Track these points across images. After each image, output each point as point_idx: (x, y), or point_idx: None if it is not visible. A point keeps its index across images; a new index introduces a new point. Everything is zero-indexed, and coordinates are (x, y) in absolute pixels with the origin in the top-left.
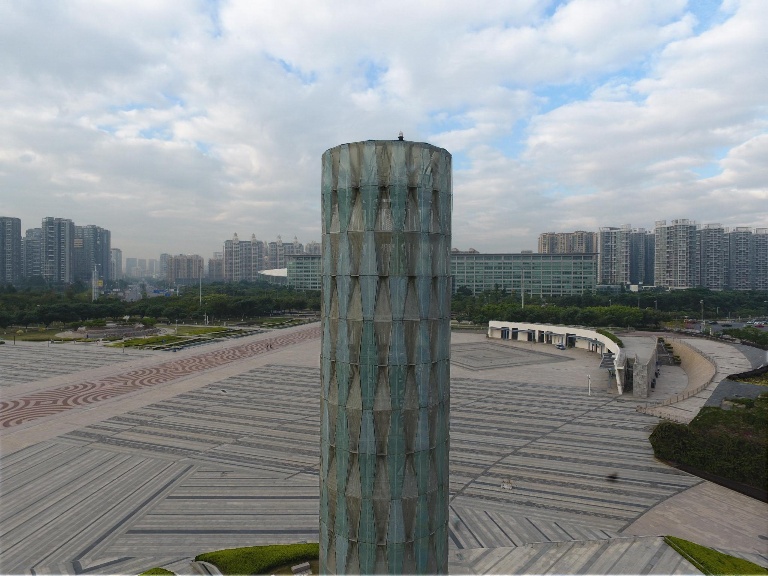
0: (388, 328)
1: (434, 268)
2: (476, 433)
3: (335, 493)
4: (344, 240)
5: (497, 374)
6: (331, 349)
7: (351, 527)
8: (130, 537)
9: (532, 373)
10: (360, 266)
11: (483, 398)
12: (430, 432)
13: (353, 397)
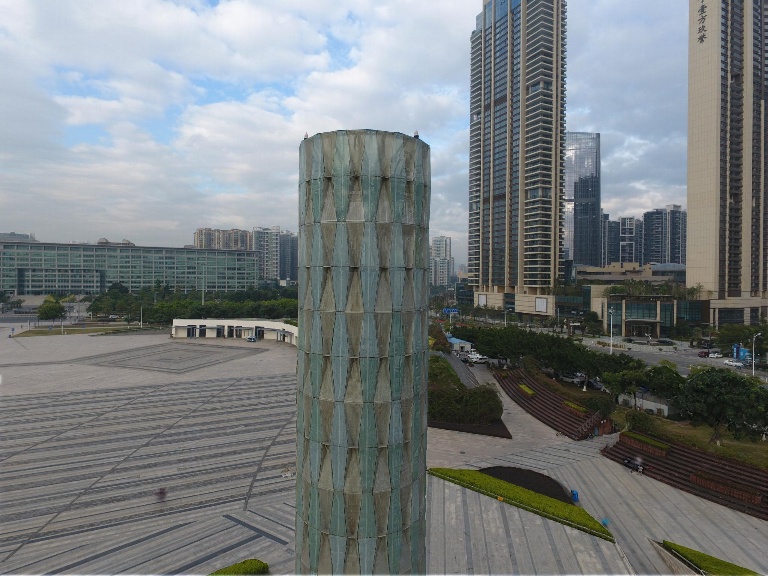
0: (411, 318)
1: None
2: (226, 435)
3: (359, 496)
4: (368, 230)
5: (207, 373)
6: (349, 345)
7: (378, 524)
8: None
9: (241, 367)
10: (390, 258)
11: (209, 399)
12: None
13: (380, 391)
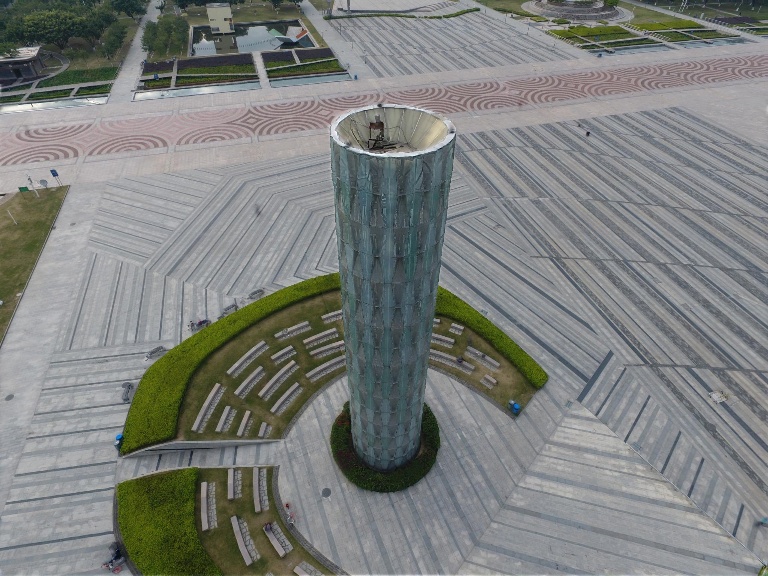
0: None
1: (379, 250)
2: None
3: None
4: None
5: None
6: None
7: None
8: None
9: None
10: None
11: None
12: (377, 339)
13: None
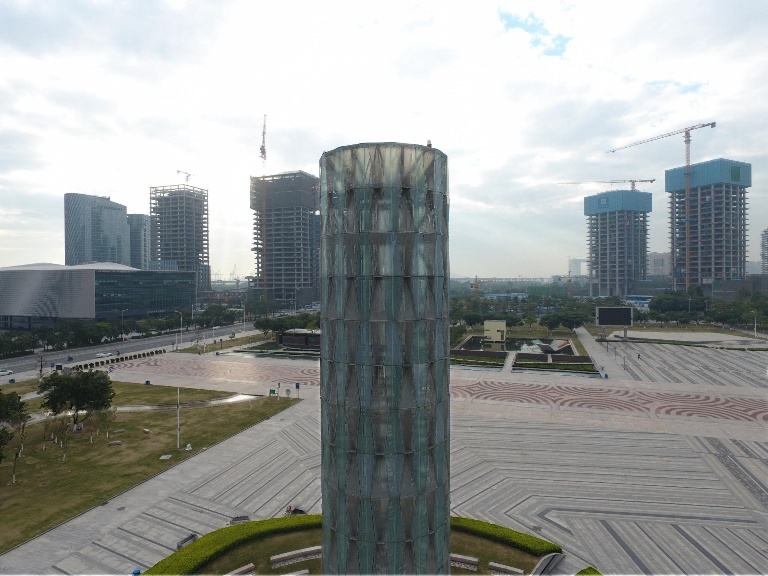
0: None
1: None
2: None
3: None
4: None
5: None
6: None
7: None
8: (596, 524)
9: None
10: None
11: None
12: None
13: None
